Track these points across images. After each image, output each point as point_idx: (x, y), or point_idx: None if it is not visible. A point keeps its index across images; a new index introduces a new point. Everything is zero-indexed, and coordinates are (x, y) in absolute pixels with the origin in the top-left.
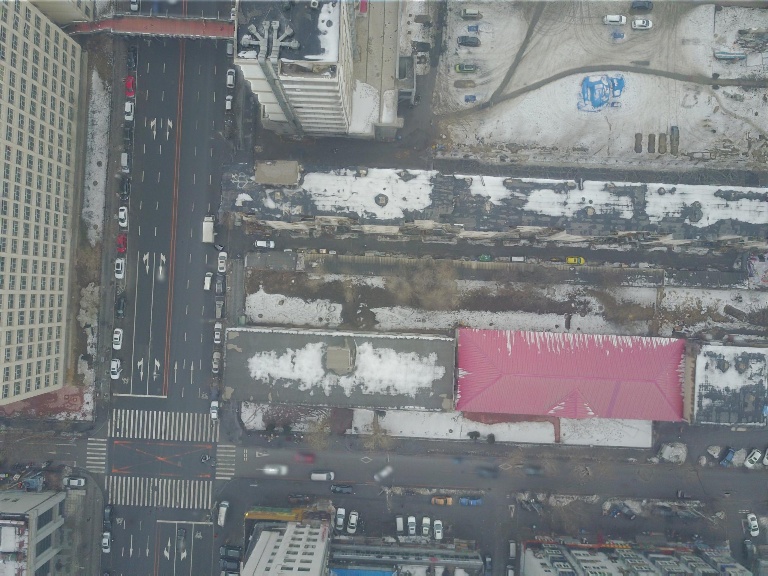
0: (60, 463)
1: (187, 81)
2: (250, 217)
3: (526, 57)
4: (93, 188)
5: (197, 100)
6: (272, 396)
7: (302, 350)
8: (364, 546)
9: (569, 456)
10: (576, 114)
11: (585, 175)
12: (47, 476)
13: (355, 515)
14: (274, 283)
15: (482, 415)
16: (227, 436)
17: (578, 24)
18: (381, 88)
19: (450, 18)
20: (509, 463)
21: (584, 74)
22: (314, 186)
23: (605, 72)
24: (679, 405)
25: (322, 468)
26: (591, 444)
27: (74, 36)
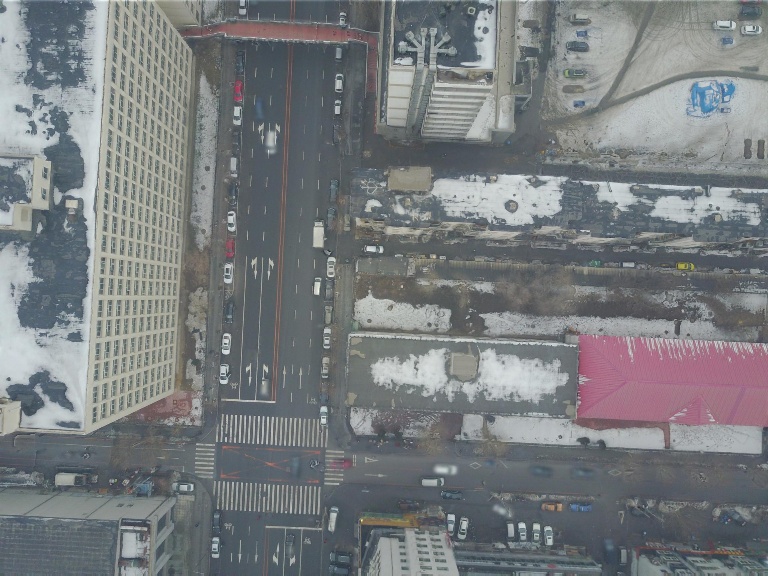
0: (168, 468)
1: (295, 86)
2: (371, 223)
3: (635, 62)
4: (201, 193)
5: (305, 105)
6: (395, 402)
7: (425, 356)
8: (477, 552)
9: (679, 462)
10: (685, 120)
11: (694, 181)
12: (156, 481)
13: (466, 521)
14: (383, 288)
15: (592, 421)
16: (336, 441)
17: (687, 29)
18: (497, 93)
19: (559, 23)
20: (618, 469)
21: (693, 79)
22: (444, 192)
23: (714, 78)
24: None
25: (431, 474)
26: (701, 450)
27: (184, 40)
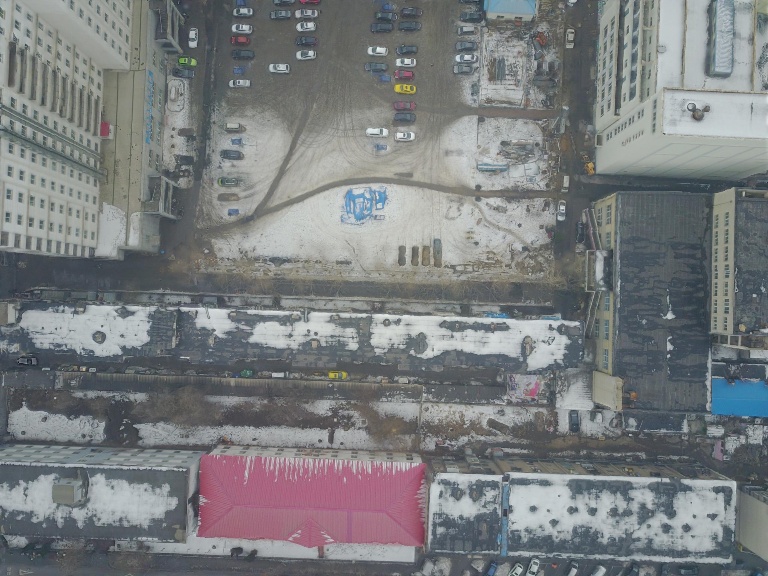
0: None
1: None
2: None
3: (290, 170)
4: None
5: None
6: (5, 528)
7: (34, 482)
8: None
9: (333, 571)
10: (340, 227)
11: (349, 288)
12: None
13: None
14: (37, 400)
15: None
16: None
17: (341, 136)
18: (128, 210)
19: (214, 131)
20: None
21: (347, 187)
22: (31, 324)
23: (369, 184)
24: (419, 531)
25: None
26: (354, 559)
27: None
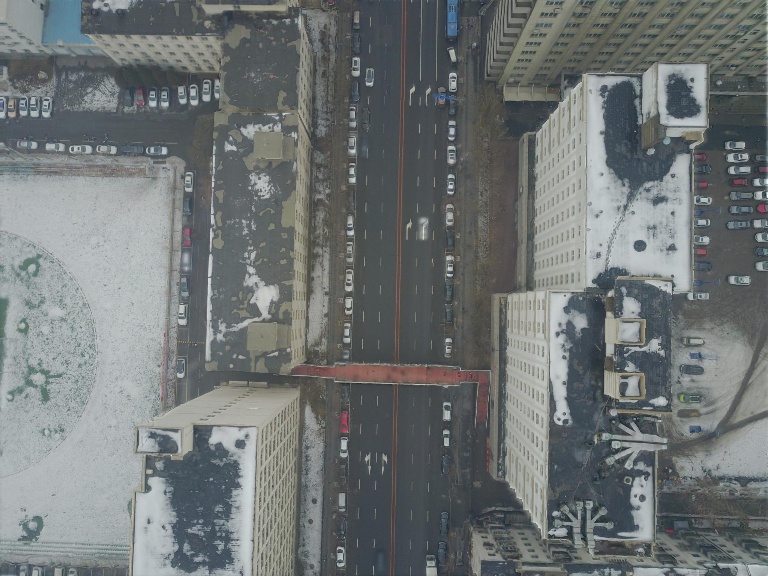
0: None
1: (401, 413)
2: None
3: (752, 385)
4: (308, 526)
5: (412, 433)
6: None
7: None
8: None
9: None
10: None
11: None
12: None
13: None
14: None
15: None
16: None
17: None
18: None
19: None
20: None
21: None
22: None
23: None
24: None
25: None
26: None
27: None
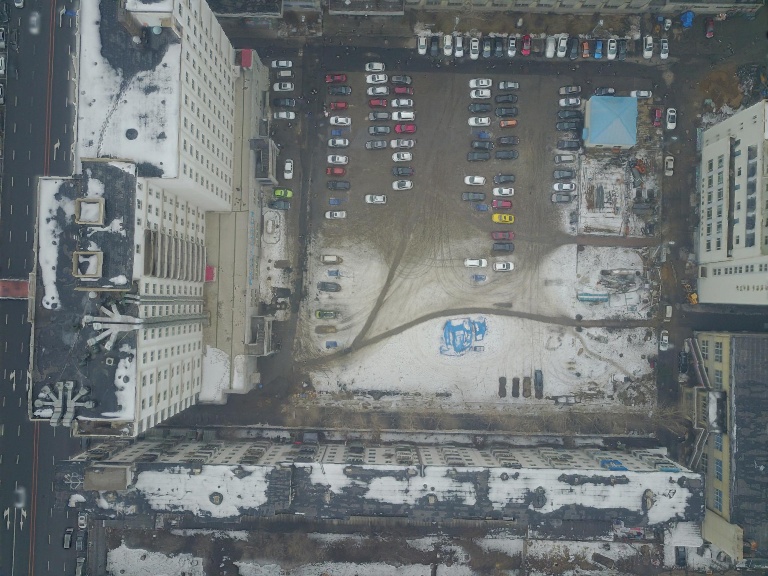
0: None
1: None
2: None
3: (387, 301)
4: None
5: None
6: None
7: None
8: None
9: None
10: (439, 358)
11: (449, 421)
12: None
13: None
14: (136, 538)
15: None
16: None
17: (439, 267)
18: (232, 353)
19: (310, 263)
20: None
21: (446, 318)
22: (148, 485)
23: (467, 315)
24: None
25: None
26: None
27: None
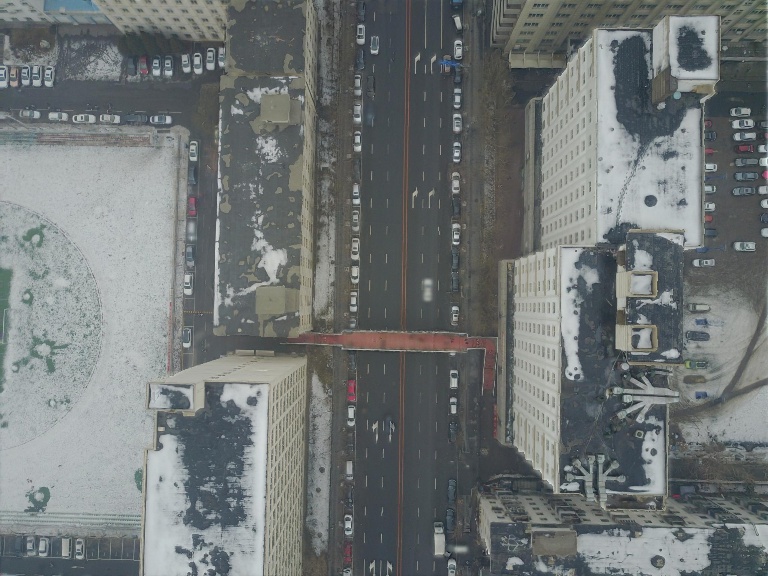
0: None
1: (408, 382)
2: None
3: (758, 350)
4: (316, 495)
5: (419, 401)
6: None
7: None
8: None
9: None
10: None
11: None
12: None
13: None
14: None
15: None
16: None
17: None
18: None
19: None
20: None
21: None
22: (587, 548)
23: None
24: None
25: None
26: None
27: None
